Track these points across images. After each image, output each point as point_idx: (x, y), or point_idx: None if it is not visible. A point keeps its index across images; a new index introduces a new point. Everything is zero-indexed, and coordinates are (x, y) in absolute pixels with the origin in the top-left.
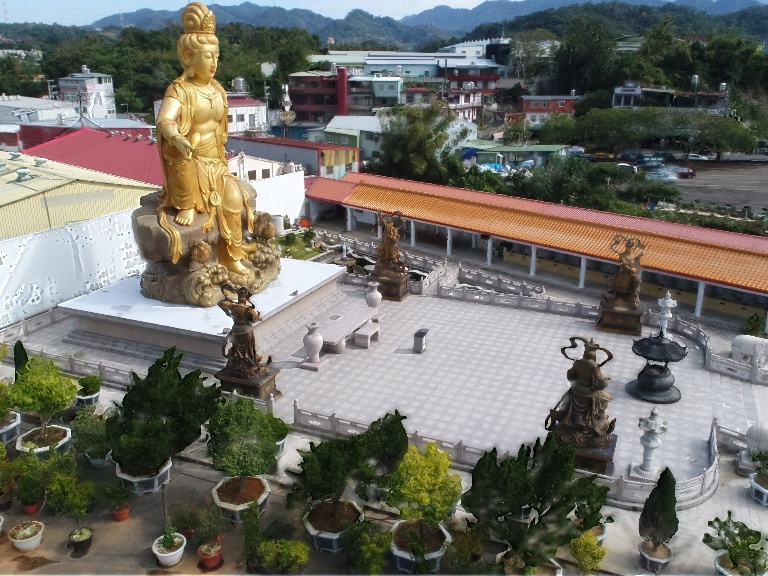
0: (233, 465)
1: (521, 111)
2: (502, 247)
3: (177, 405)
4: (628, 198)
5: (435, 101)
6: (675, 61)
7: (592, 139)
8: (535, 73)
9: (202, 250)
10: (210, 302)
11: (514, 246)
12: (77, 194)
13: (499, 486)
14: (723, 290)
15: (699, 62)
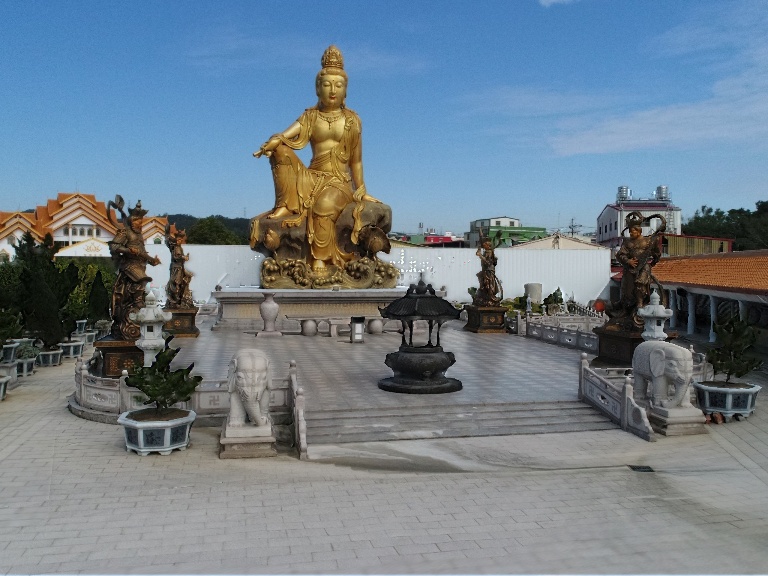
0: None
1: None
2: None
3: None
4: None
5: None
6: None
7: None
8: None
9: (267, 237)
10: (268, 285)
11: None
12: None
13: None
14: None
15: None
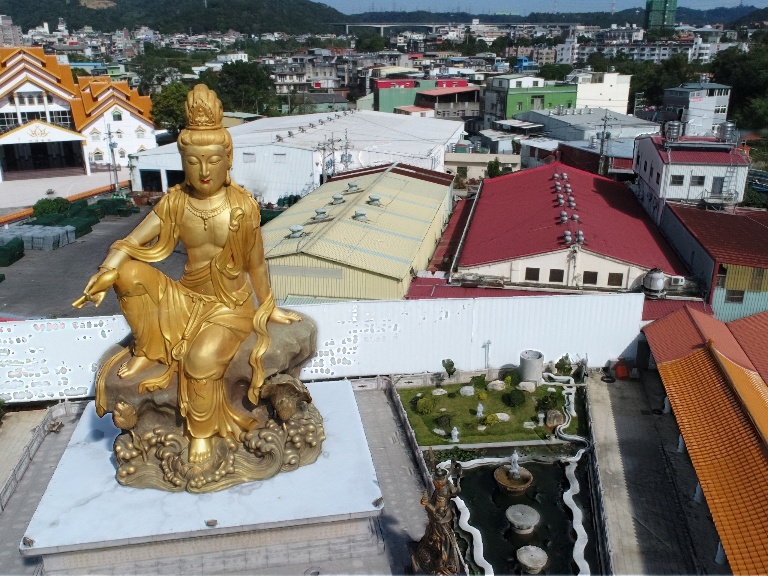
0: None
1: None
2: None
3: None
4: None
5: None
6: None
7: None
8: None
9: (115, 415)
10: (125, 480)
11: None
12: (303, 267)
13: None
14: None
15: None
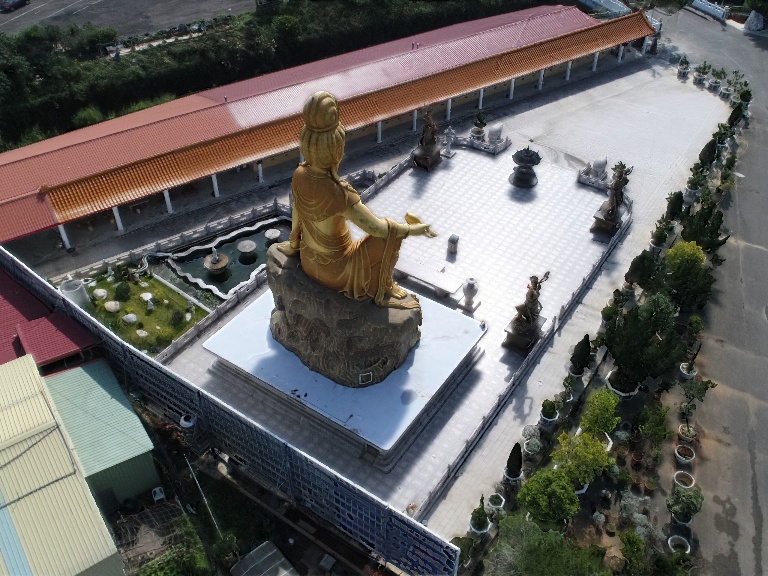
0: None
1: None
2: None
3: None
4: (72, 56)
5: None
6: None
7: None
8: None
9: (418, 300)
10: None
11: None
12: None
13: None
14: None
15: None
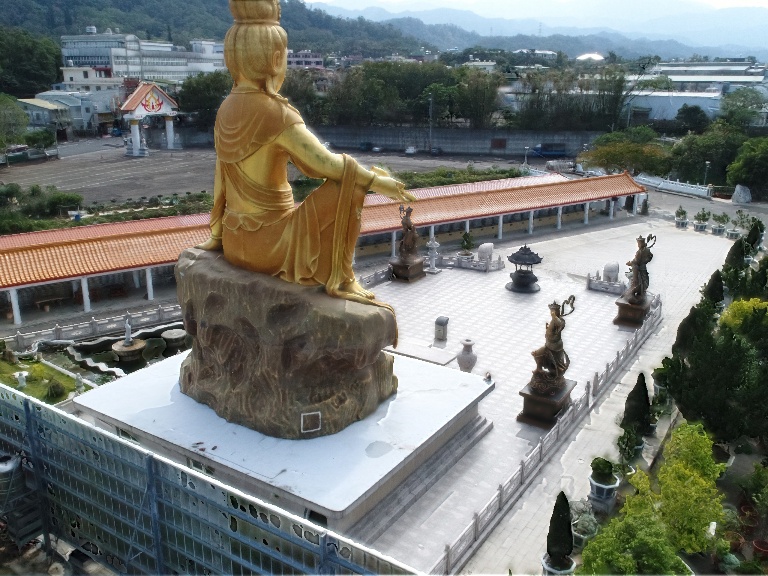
0: None
1: None
2: None
3: None
4: None
5: None
6: None
7: None
8: None
9: None
10: None
11: None
12: None
13: None
14: (381, 236)
15: None
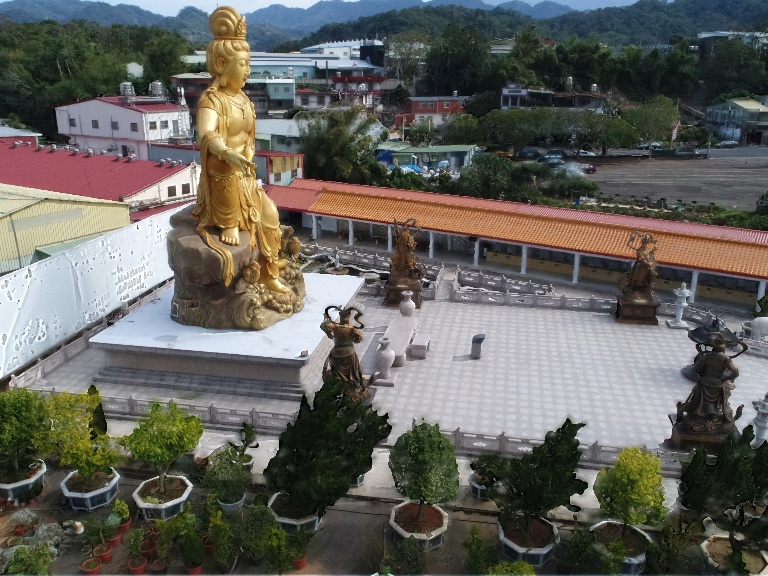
0: (431, 493)
1: (410, 112)
2: (482, 248)
3: (339, 438)
4: (551, 194)
5: (355, 104)
6: (544, 63)
7: (495, 139)
8: (415, 74)
9: (255, 270)
10: (262, 324)
11: (496, 246)
12: (45, 215)
13: (735, 480)
14: (707, 277)
15: (564, 64)
